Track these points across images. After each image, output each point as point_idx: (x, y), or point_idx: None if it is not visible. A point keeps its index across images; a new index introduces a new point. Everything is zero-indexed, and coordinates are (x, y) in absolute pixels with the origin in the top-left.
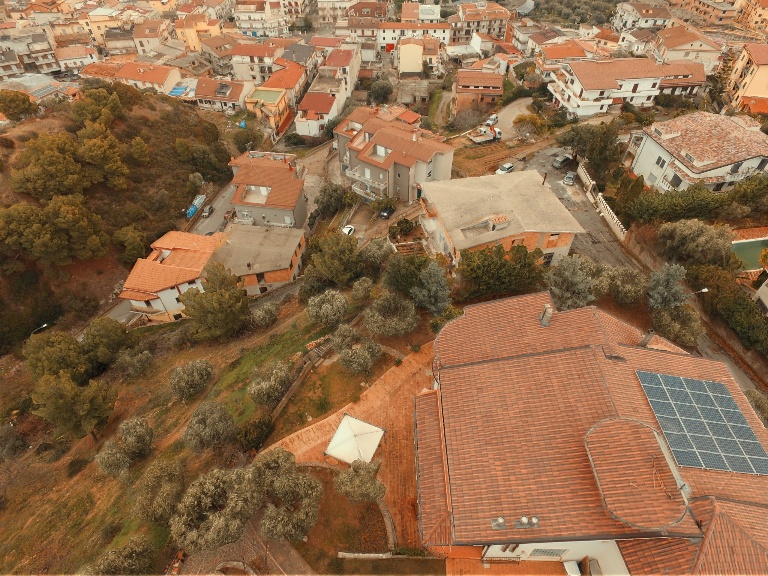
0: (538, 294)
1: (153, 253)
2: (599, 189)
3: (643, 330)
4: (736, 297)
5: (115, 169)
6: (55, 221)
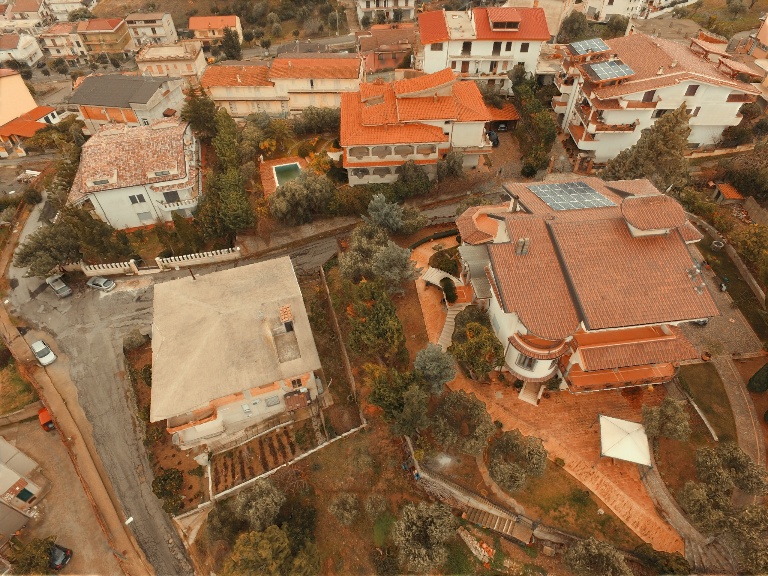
0: (492, 252)
1: None
2: (140, 261)
3: (402, 246)
4: (370, 190)
5: None
6: None
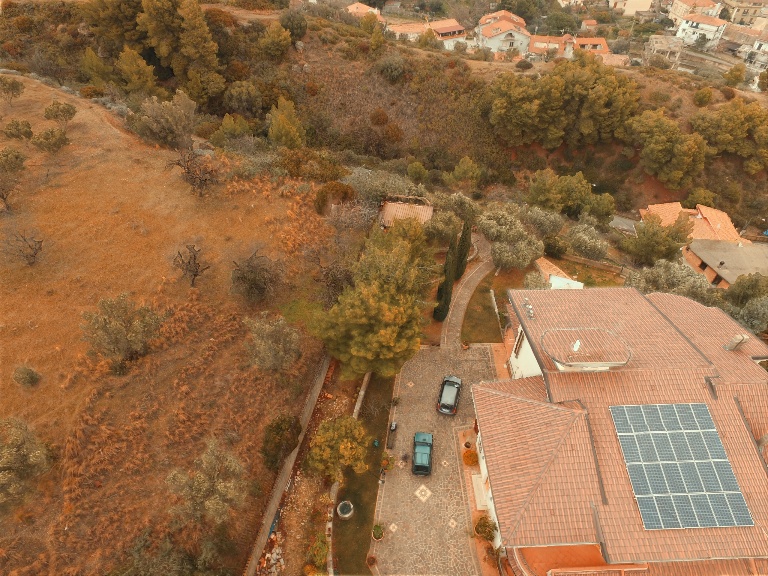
0: None
1: (692, 210)
2: None
3: None
4: None
5: (764, 156)
6: (676, 145)
